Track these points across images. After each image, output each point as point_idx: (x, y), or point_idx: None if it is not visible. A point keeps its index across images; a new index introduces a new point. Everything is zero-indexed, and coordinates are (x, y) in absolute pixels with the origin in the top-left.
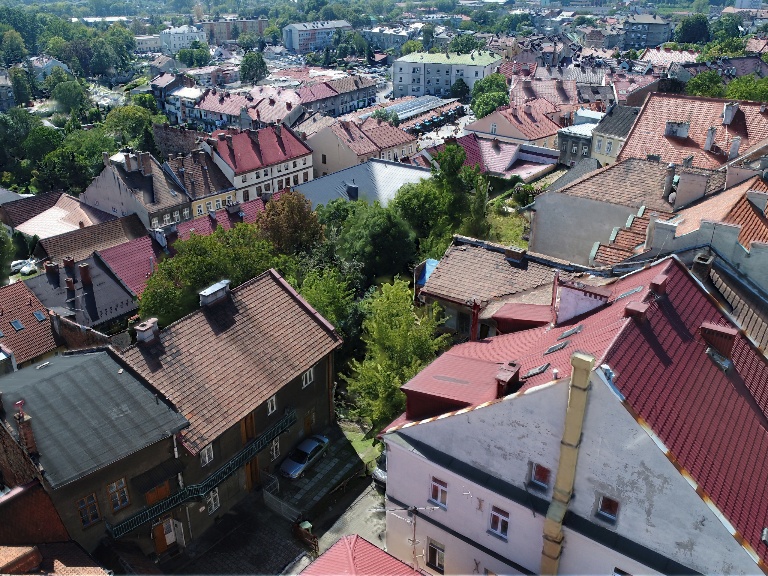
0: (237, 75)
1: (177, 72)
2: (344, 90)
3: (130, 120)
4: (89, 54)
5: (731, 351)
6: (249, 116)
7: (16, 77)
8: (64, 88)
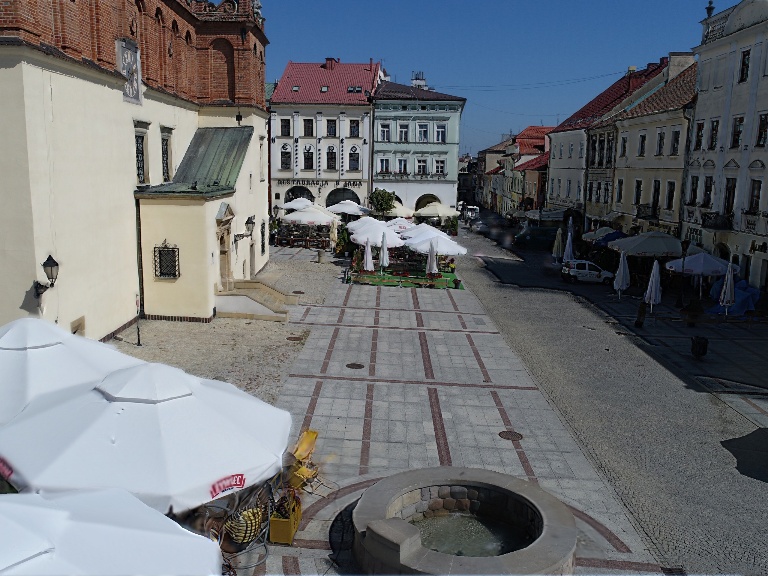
0: None
1: None
2: None
3: None
4: None
5: (631, 88)
6: None
7: None
8: None
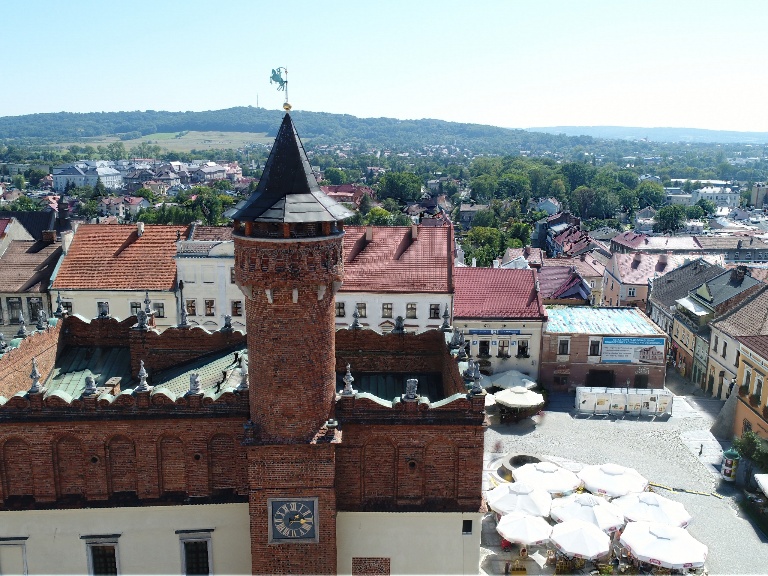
0: (650, 224)
1: (636, 220)
2: (715, 247)
3: (482, 237)
4: (591, 200)
5: None
6: (563, 248)
7: (495, 207)
8: (479, 213)
